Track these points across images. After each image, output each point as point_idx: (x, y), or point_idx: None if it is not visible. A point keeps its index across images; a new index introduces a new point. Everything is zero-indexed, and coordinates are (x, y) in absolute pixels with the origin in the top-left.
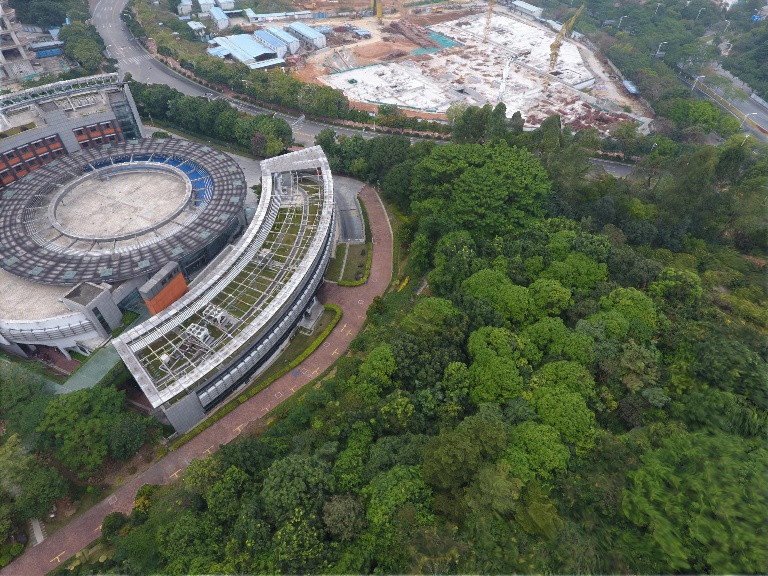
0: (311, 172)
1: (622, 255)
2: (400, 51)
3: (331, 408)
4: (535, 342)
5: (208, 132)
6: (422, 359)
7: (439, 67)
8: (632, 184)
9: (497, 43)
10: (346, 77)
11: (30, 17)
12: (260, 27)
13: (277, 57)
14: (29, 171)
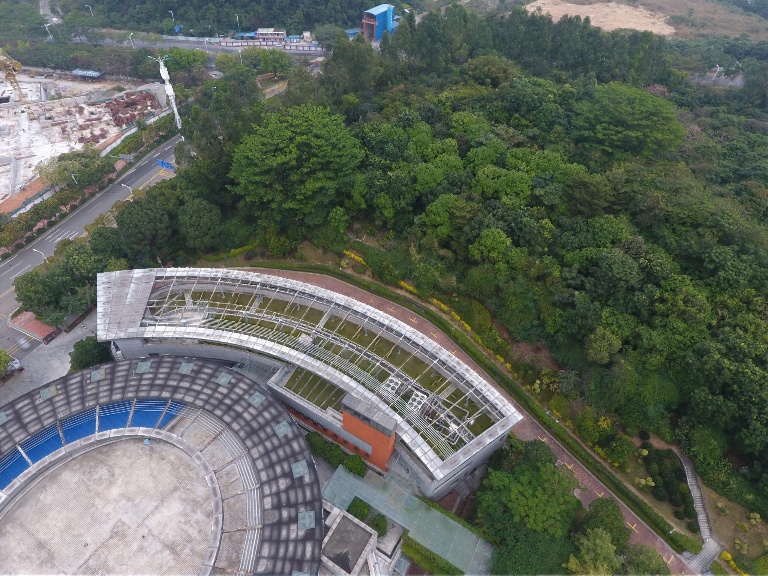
0: None
1: None
2: None
3: (537, 270)
4: None
5: None
6: None
7: None
8: None
9: None
10: None
11: None
12: None
13: None
14: None
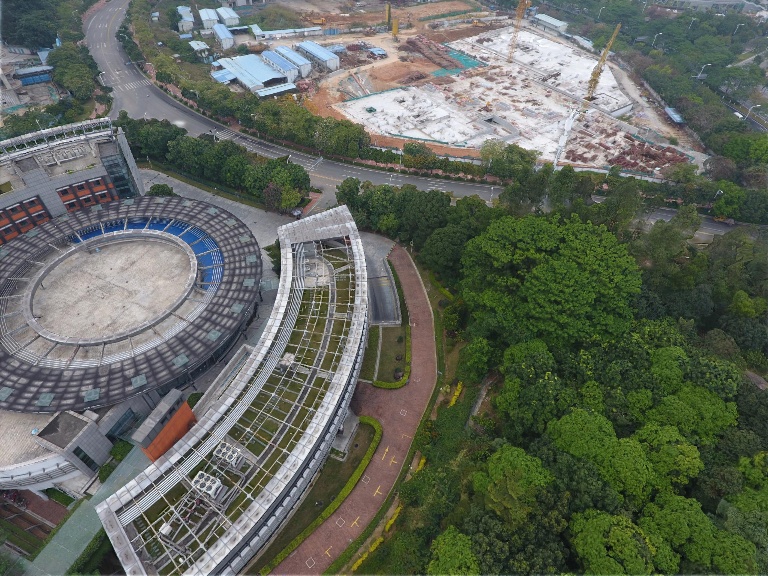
0: (337, 239)
1: (751, 386)
2: (420, 73)
3: None
4: (667, 539)
5: (214, 179)
6: (517, 569)
7: (463, 91)
8: (730, 267)
9: (523, 63)
10: (363, 105)
11: (17, 38)
12: (267, 46)
13: (287, 81)
14: (4, 240)
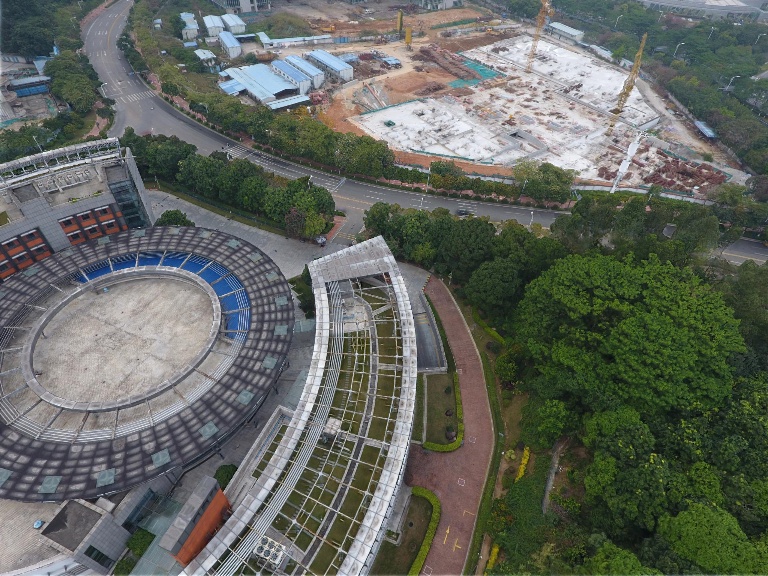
0: None
1: None
2: (437, 84)
3: None
4: None
5: (229, 202)
6: None
7: (483, 103)
8: None
9: (542, 73)
10: (381, 118)
11: (11, 45)
12: (276, 55)
13: (299, 93)
14: None
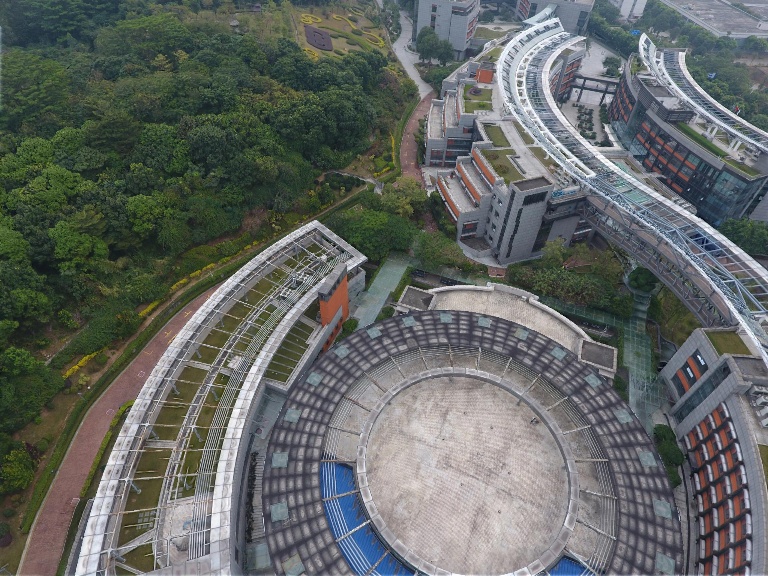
0: None
1: None
2: None
3: None
4: None
5: None
6: None
7: None
8: None
9: None
10: None
11: None
12: None
13: None
14: None
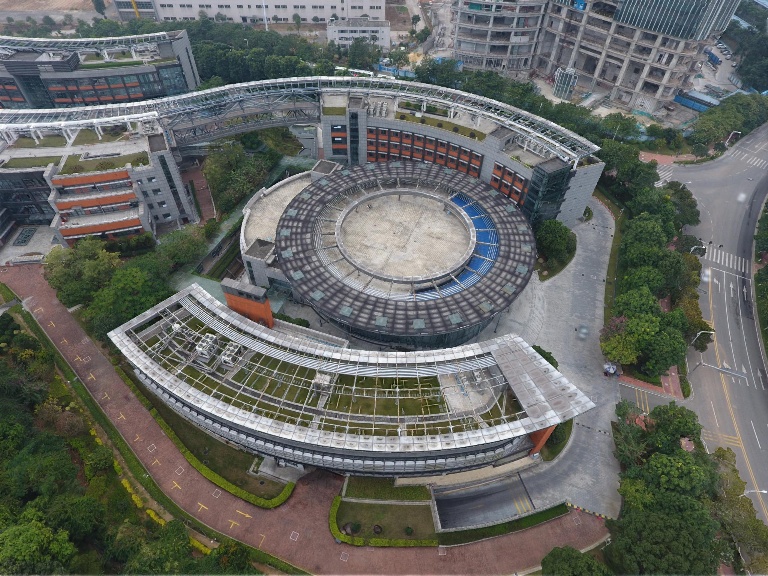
0: None
1: None
2: None
3: None
4: None
5: (621, 269)
6: None
7: None
8: None
9: None
10: None
11: (746, 70)
12: None
13: None
14: (446, 164)
